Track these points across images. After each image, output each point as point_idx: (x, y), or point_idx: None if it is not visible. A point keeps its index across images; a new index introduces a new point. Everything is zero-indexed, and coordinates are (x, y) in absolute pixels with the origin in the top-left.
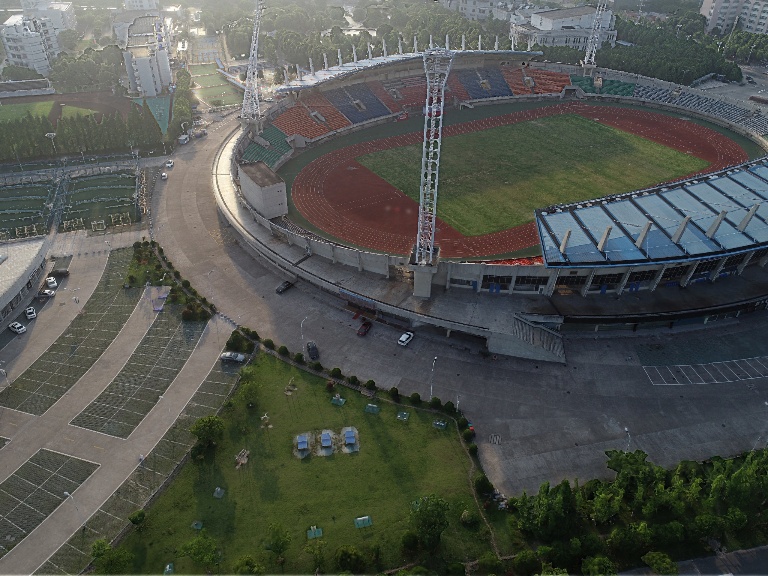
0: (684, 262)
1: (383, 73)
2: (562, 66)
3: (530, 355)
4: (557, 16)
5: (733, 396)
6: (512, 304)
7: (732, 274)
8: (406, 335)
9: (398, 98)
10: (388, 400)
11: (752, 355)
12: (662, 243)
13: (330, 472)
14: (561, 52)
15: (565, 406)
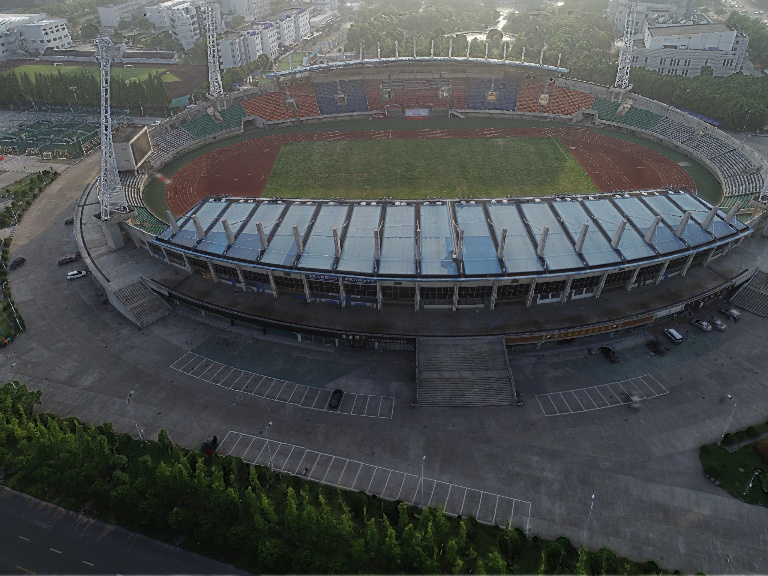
0: (246, 266)
1: (386, 73)
2: (592, 87)
3: (124, 313)
4: (667, 33)
5: (209, 399)
6: (157, 271)
7: (372, 306)
8: (76, 272)
9: (390, 98)
10: (1, 307)
11: (289, 379)
12: (253, 246)
13: None
14: (627, 73)
15: (87, 354)
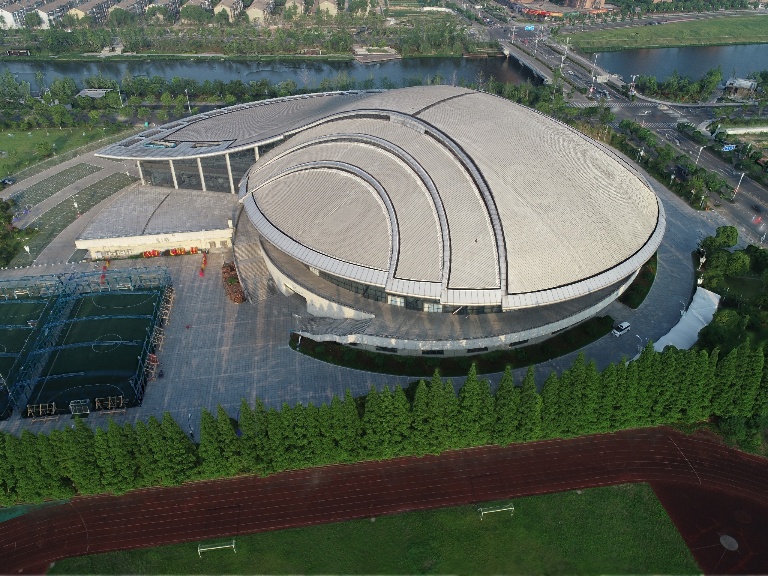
0: None
1: None
2: None
3: None
4: None
5: None
6: None
7: None
8: None
9: None
10: None
11: None
12: None
13: (8, 147)
14: None
15: None
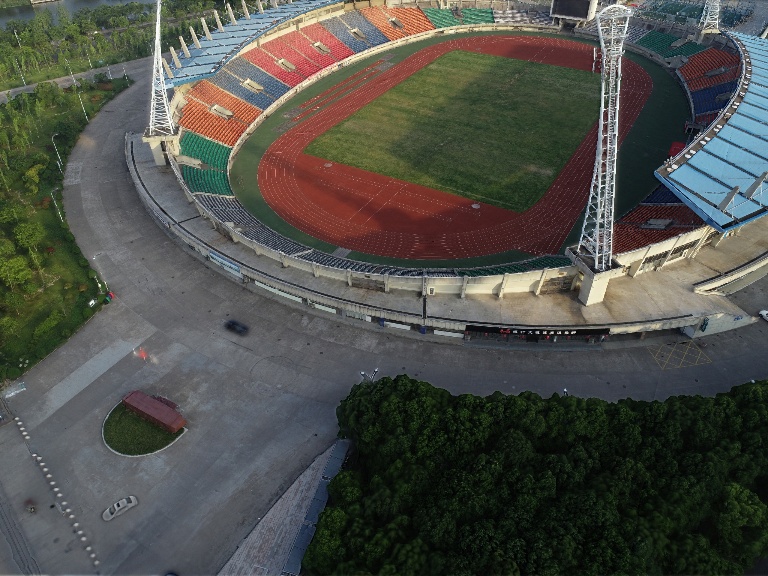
0: None
1: None
2: (644, 252)
3: None
4: None
5: None
6: None
7: None
8: None
9: None
10: None
11: None
12: None
13: None
14: None
15: None
